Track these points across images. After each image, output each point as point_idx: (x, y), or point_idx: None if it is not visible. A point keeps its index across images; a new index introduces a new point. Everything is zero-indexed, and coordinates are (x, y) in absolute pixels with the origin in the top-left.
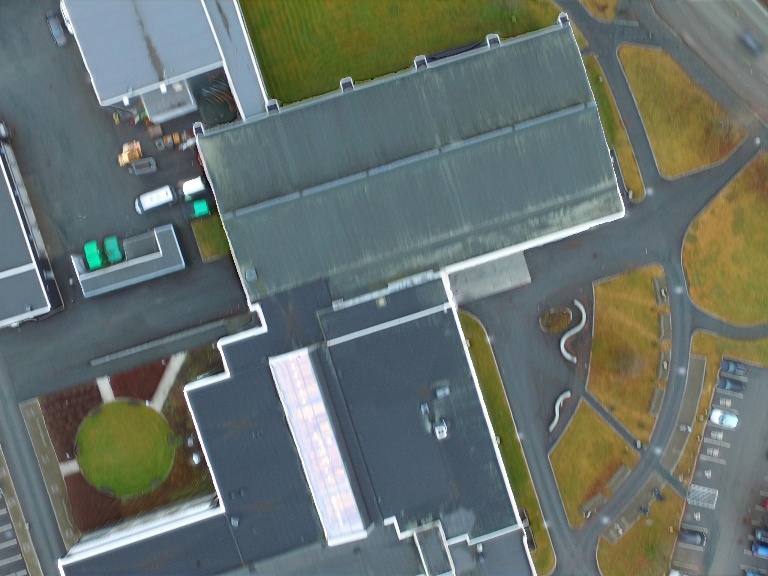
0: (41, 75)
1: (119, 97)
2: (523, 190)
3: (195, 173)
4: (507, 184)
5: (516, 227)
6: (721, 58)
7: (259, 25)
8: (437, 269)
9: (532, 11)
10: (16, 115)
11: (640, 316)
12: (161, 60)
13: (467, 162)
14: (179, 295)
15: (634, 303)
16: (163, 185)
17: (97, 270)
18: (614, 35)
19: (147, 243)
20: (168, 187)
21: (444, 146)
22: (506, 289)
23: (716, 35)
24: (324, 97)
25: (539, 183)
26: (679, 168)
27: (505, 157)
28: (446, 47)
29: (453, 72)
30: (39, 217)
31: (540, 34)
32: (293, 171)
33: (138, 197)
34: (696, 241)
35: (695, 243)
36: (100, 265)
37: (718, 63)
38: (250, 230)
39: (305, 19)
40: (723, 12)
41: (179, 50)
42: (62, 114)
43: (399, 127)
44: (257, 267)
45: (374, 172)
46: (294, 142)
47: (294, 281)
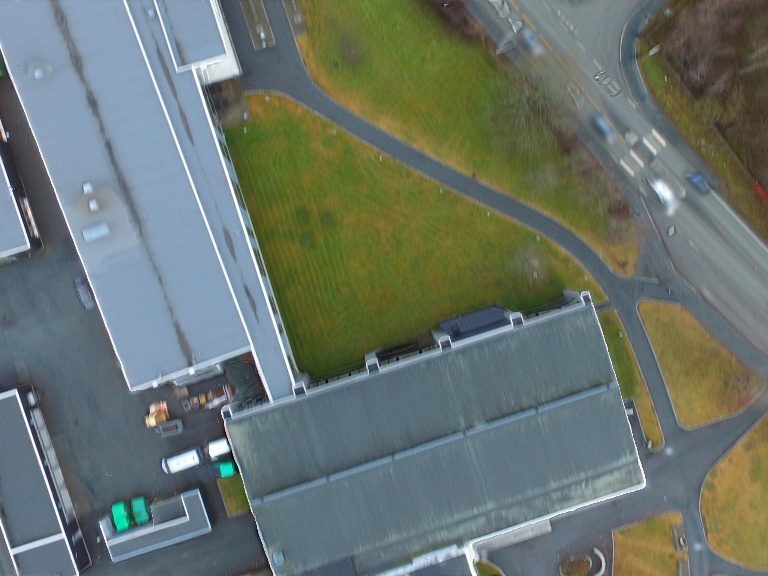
0: (69, 337)
1: (149, 383)
2: (546, 468)
3: (221, 432)
4: (530, 462)
5: (539, 500)
6: (739, 312)
7: (284, 285)
8: (461, 544)
9: (553, 266)
10: (44, 377)
11: (659, 563)
12: (190, 345)
13: (491, 442)
14: (205, 550)
15: (653, 551)
16: (190, 449)
17: (125, 535)
18: (634, 291)
19: (174, 507)
20: (195, 451)
21: (468, 429)
22: (527, 538)
23: (734, 290)
24: (350, 379)
25: (562, 460)
26: (698, 419)
27: (528, 437)
28: (468, 303)
29: (477, 354)
30: (67, 476)
31: (563, 312)
32: (320, 455)
33: (165, 458)
34: (714, 489)
35: (713, 491)
36: (127, 527)
37: (736, 317)
38: (277, 513)
39: (329, 278)
40: (741, 267)
41: (208, 335)
42: (90, 375)
43: (424, 410)
44: (284, 550)
45: (400, 456)
46: (321, 426)
47: (320, 560)
